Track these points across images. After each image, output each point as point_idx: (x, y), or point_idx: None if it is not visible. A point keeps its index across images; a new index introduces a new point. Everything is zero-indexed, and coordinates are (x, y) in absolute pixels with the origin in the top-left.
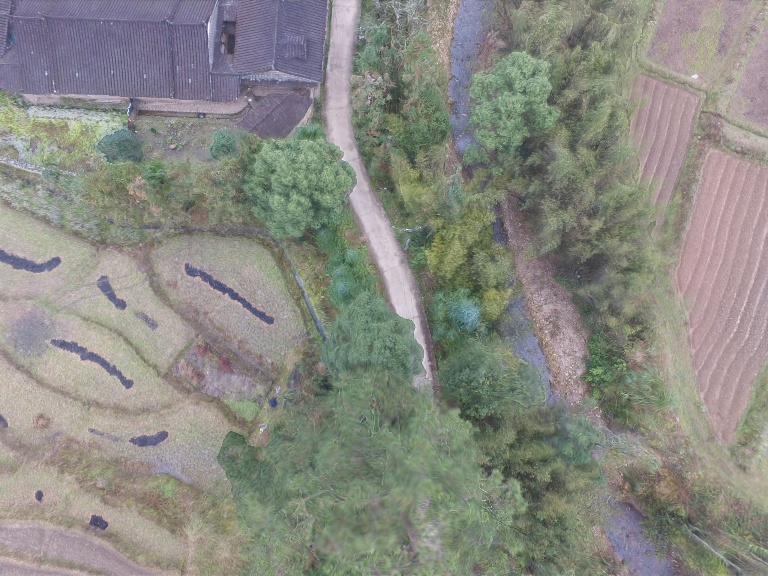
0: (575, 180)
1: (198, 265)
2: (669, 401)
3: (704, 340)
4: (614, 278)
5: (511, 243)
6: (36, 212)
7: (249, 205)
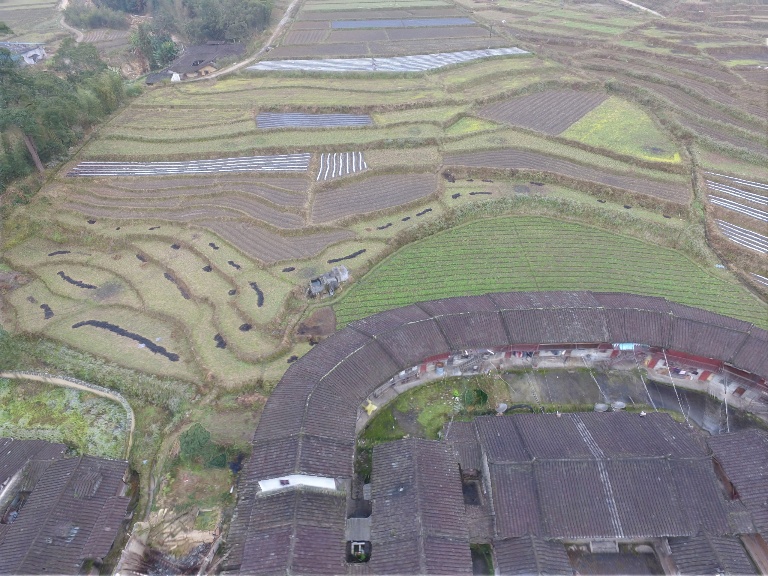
0: None
1: None
2: None
3: None
4: None
5: None
6: None
7: None
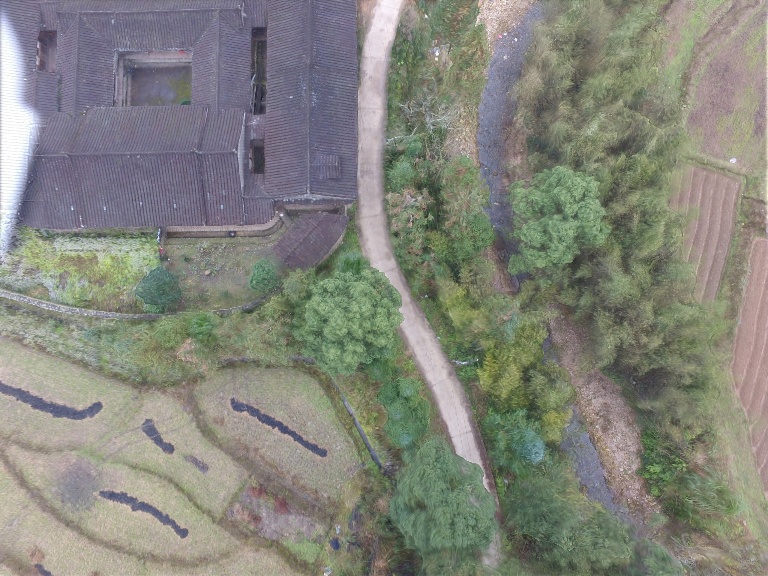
0: (631, 299)
1: (244, 399)
2: (736, 508)
3: (764, 437)
4: (676, 393)
5: (554, 335)
6: (73, 355)
7: (298, 346)
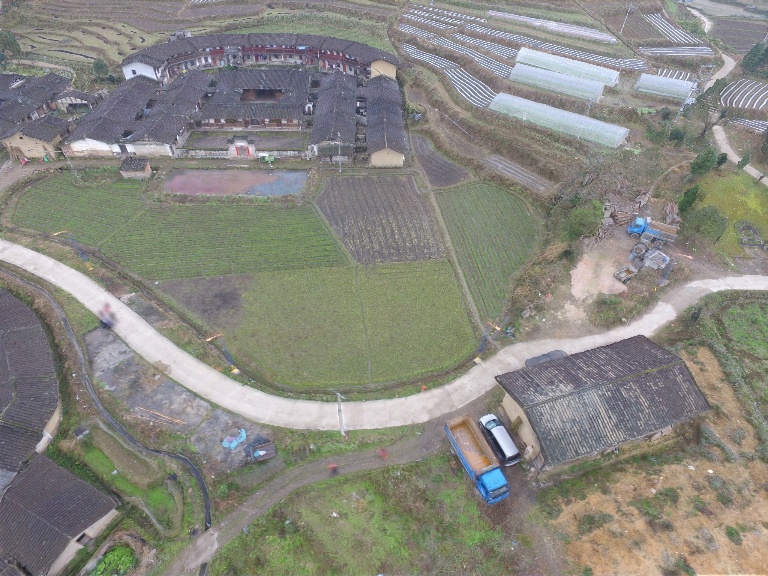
0: None
1: None
2: None
3: None
4: None
5: None
6: None
7: None
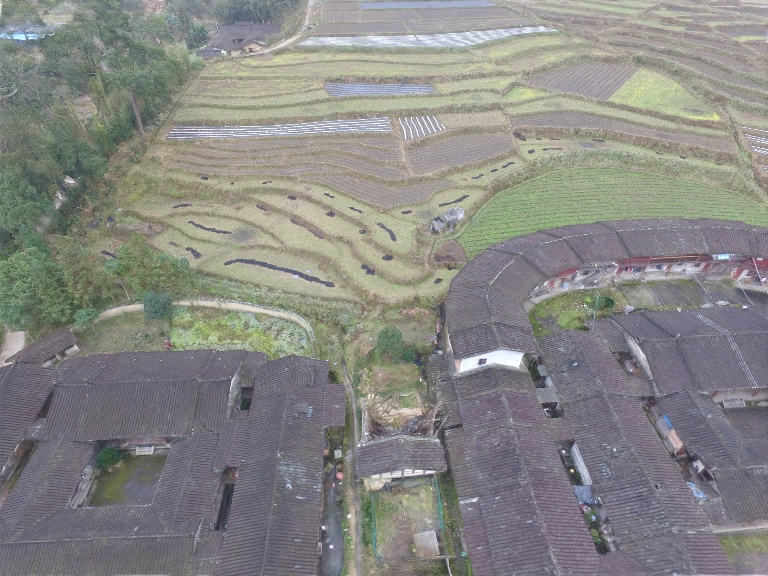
0: None
1: None
2: None
3: None
4: None
5: None
6: None
7: None
